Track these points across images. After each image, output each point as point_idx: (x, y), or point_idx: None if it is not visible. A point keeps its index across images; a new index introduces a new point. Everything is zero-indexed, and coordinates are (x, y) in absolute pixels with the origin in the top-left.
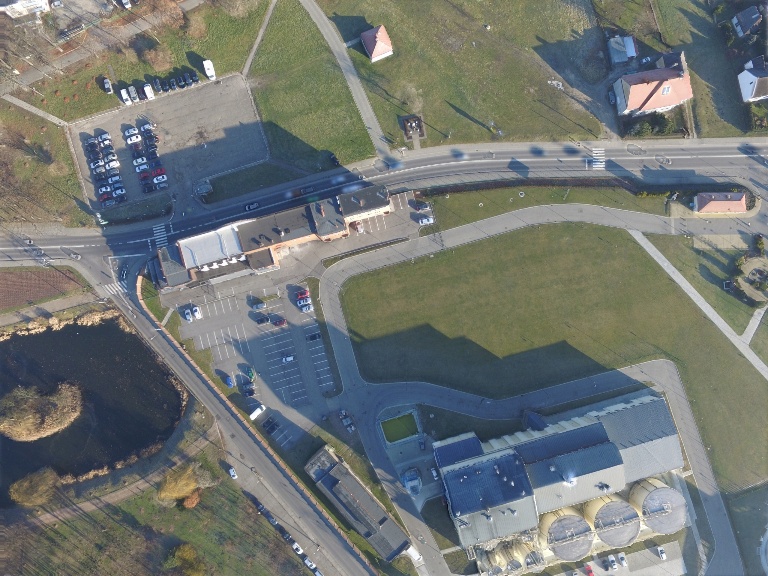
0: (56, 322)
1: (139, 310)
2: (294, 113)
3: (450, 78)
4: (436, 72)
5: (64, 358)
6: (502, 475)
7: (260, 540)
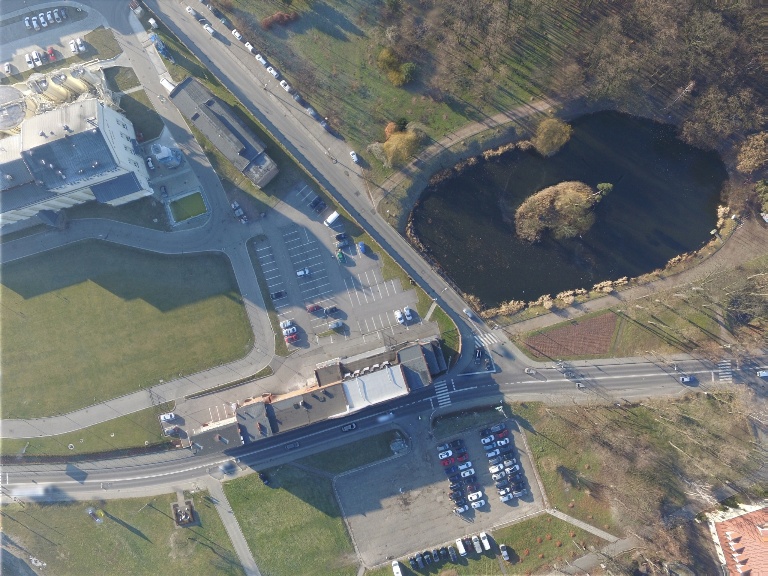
0: (545, 303)
1: (461, 318)
2: (309, 527)
3: (147, 567)
4: (162, 573)
5: (537, 266)
6: (56, 170)
7: (325, 92)
